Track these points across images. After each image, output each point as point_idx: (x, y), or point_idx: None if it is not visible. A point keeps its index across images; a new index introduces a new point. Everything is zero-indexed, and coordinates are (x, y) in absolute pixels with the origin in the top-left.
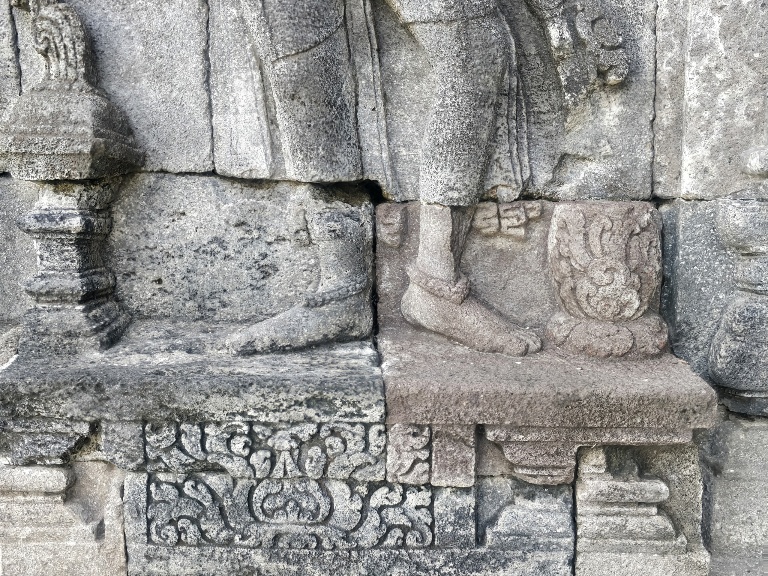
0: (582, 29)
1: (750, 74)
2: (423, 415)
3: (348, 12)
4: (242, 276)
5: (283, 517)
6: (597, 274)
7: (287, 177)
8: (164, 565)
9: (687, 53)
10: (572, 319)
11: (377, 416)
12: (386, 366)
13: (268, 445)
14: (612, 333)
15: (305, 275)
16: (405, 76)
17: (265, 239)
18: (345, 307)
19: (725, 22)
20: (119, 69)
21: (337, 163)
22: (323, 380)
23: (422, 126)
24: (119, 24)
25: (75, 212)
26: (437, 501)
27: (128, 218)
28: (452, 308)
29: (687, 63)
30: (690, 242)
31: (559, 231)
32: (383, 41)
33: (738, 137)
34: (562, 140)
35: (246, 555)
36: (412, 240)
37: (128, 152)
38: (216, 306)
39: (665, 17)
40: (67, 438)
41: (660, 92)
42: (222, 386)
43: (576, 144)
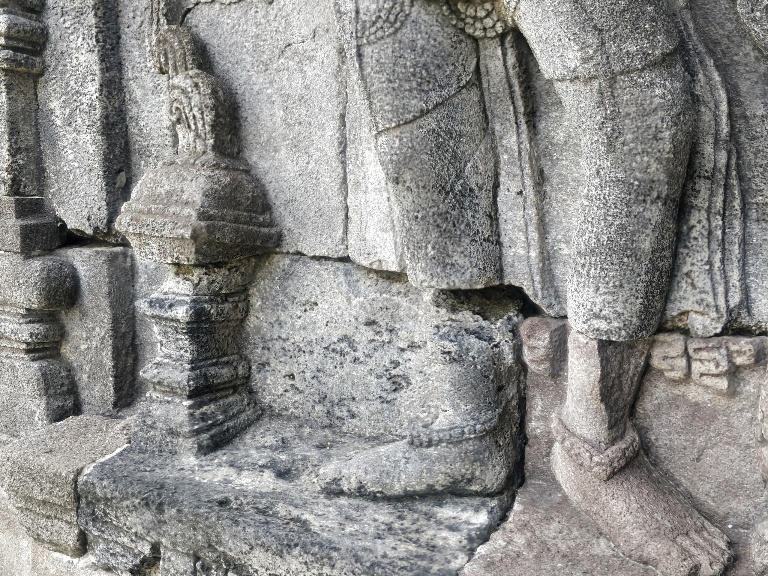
0: None
1: None
2: None
3: (483, 66)
4: (371, 385)
5: None
6: None
7: None
8: None
9: None
10: None
11: None
12: (477, 553)
13: None
14: None
15: None
16: (568, 147)
17: (397, 344)
18: (459, 453)
19: None
20: (260, 137)
21: (453, 266)
22: (376, 561)
23: None
24: (262, 87)
25: (187, 299)
26: None
27: (263, 303)
28: (594, 484)
29: None
30: None
31: (764, 399)
32: (540, 100)
33: None
34: None
35: None
36: None
37: (248, 234)
38: (344, 415)
39: None
40: (133, 554)
41: None
42: (266, 539)
43: None
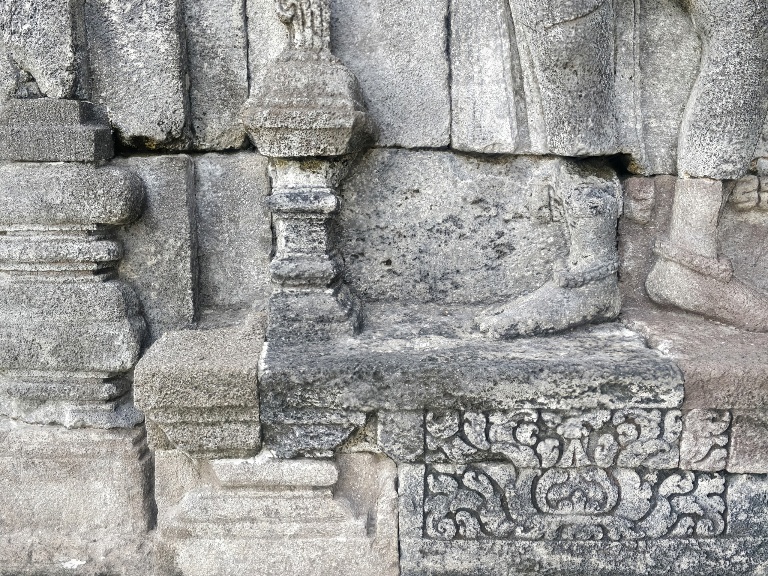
0: None
1: None
2: (725, 399)
3: None
4: (477, 256)
5: (569, 508)
6: None
7: (532, 151)
8: (440, 559)
9: None
10: None
11: (676, 401)
12: (665, 348)
13: (556, 433)
14: None
15: (543, 254)
16: (662, 43)
17: (503, 217)
18: (604, 287)
19: None
20: (354, 38)
21: (604, 135)
22: (616, 364)
23: (676, 96)
24: None
25: (326, 190)
26: (732, 488)
27: (359, 196)
28: (719, 287)
29: None
30: None
31: None
32: (640, 6)
33: None
34: None
35: (528, 548)
36: (658, 216)
37: (374, 126)
38: (448, 287)
39: None
40: (341, 429)
41: None
42: (512, 372)
43: None
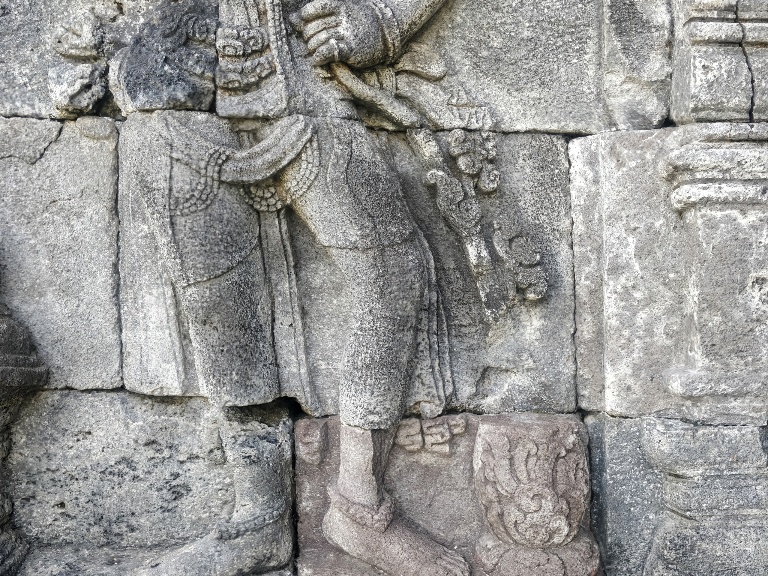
0: (500, 247)
1: (666, 294)
2: None
3: (263, 231)
4: (152, 498)
5: None
6: (524, 501)
7: (200, 394)
8: None
9: (604, 272)
10: (501, 544)
11: None
12: None
13: None
14: (542, 562)
15: (220, 495)
16: (323, 290)
17: (177, 458)
18: (261, 537)
19: (639, 243)
20: (22, 284)
21: (252, 387)
22: None
23: (341, 340)
24: (24, 238)
25: None
26: None
27: (28, 439)
28: (375, 537)
29: (604, 282)
30: (617, 461)
31: (484, 454)
32: (300, 256)
33: (658, 356)
34: (484, 353)
35: None
36: (333, 456)
37: (28, 375)
38: (123, 531)
39: (581, 233)
40: None
41: (580, 306)
42: None
43: (498, 357)
